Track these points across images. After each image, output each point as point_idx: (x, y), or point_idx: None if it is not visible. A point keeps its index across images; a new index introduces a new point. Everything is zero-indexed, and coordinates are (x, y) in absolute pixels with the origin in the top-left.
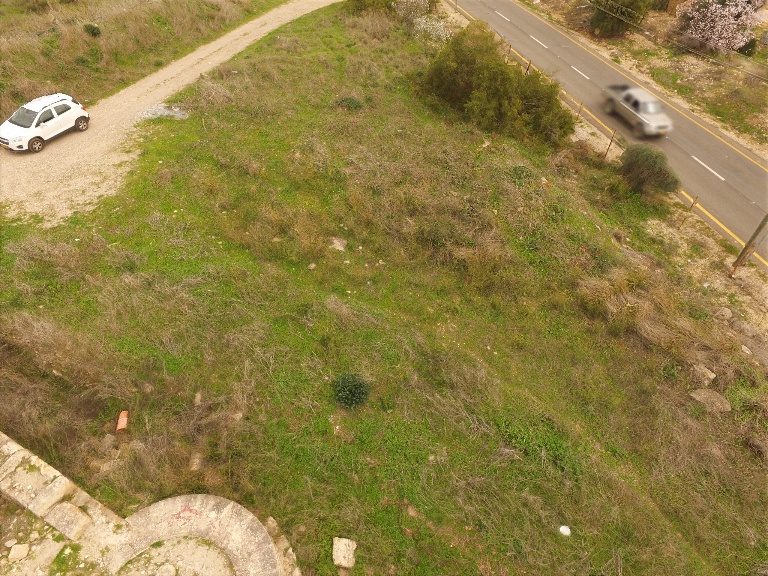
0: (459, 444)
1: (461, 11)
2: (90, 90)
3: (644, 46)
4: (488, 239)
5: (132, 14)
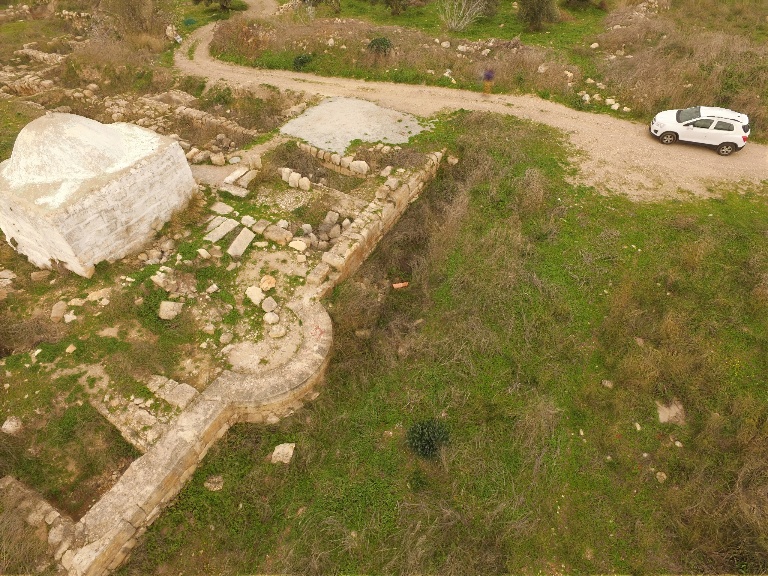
0: (369, 572)
1: None
2: None
3: None
4: None
5: None
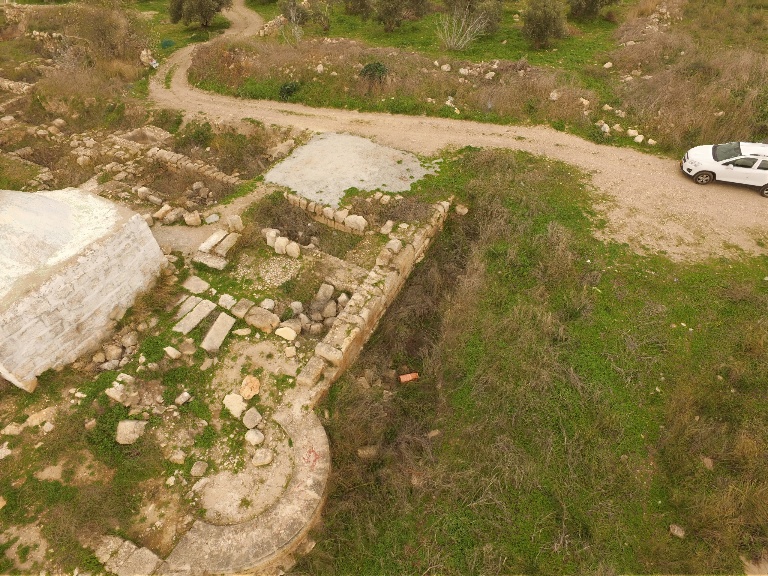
0: None
1: None
2: None
3: None
4: None
5: None
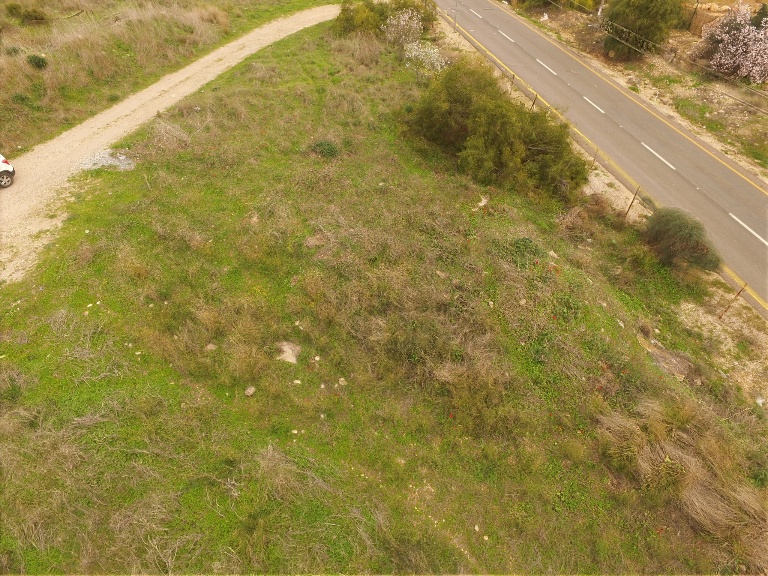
0: None
1: (460, 30)
2: (25, 134)
3: (665, 72)
4: (481, 348)
5: (88, 41)
